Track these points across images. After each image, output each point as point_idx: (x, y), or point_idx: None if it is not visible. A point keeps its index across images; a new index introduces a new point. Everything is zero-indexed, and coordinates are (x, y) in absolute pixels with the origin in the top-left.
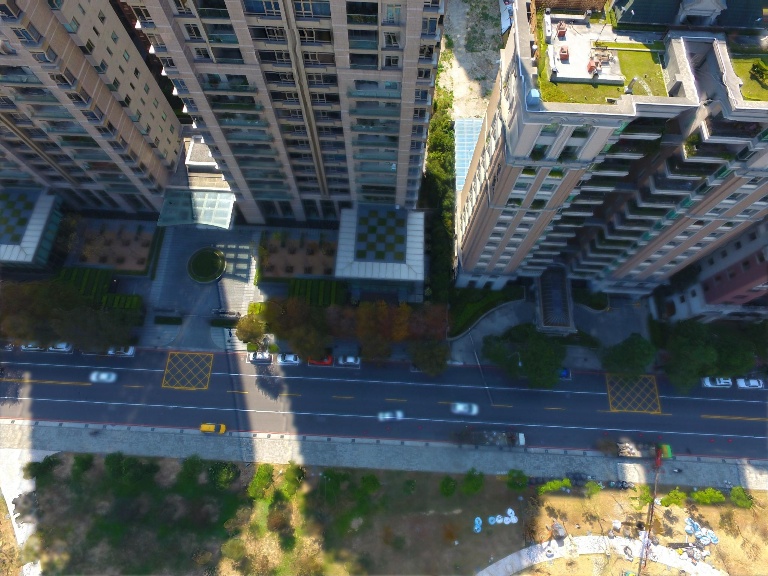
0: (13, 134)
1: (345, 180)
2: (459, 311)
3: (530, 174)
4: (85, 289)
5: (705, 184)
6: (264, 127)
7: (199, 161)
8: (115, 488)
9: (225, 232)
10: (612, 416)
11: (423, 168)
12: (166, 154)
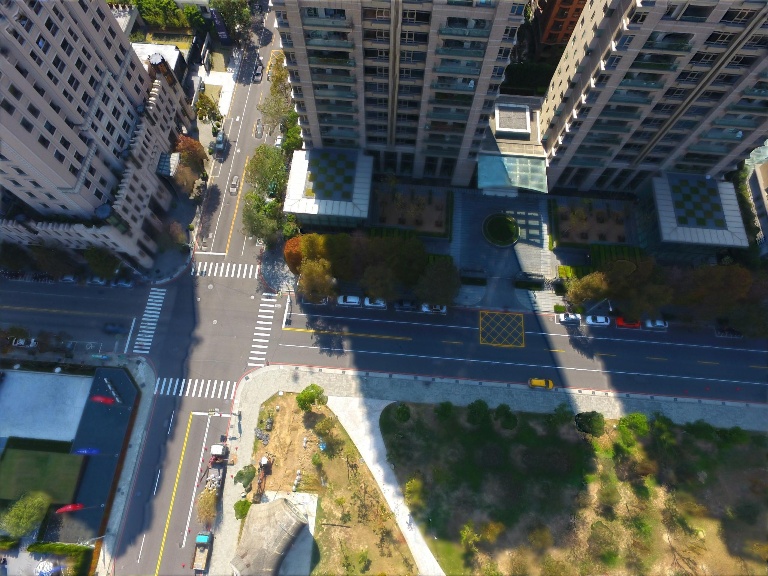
0: (381, 92)
1: (667, 148)
2: None
3: None
4: None
5: None
6: (659, 88)
7: (509, 128)
8: (460, 437)
9: (512, 199)
10: None
11: None
12: None
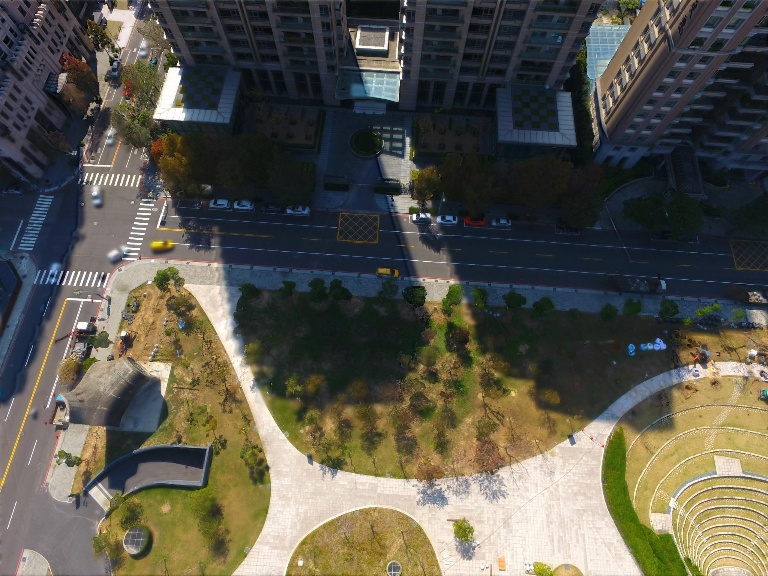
0: (230, 2)
1: (505, 59)
2: None
3: (726, 6)
4: None
5: None
6: None
7: (368, 45)
8: (308, 317)
9: (380, 116)
10: (738, 273)
11: None
12: (343, 35)
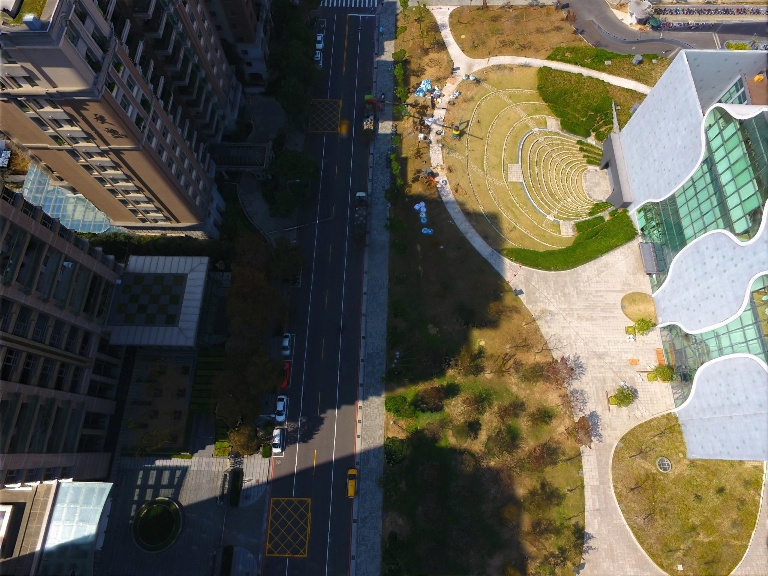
0: None
1: (72, 332)
2: None
3: (113, 88)
4: None
5: None
6: None
7: None
8: None
9: (114, 506)
10: (343, 132)
11: None
12: None
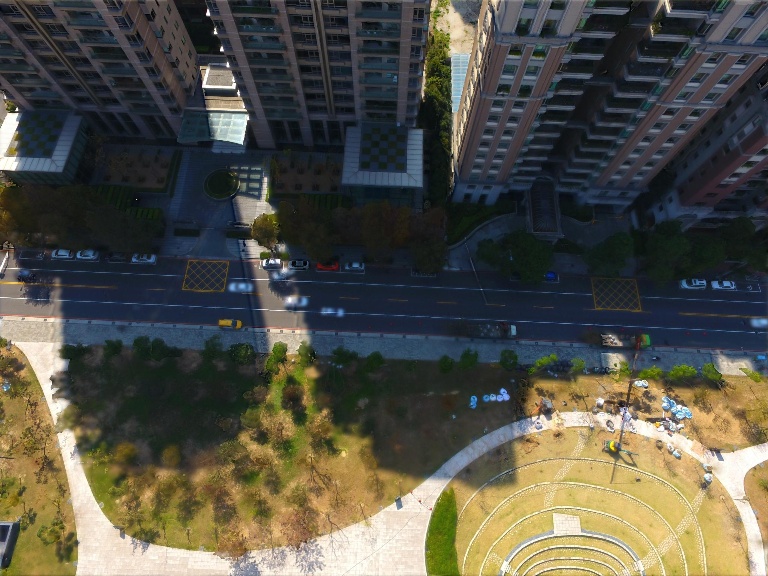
0: (48, 49)
1: (350, 97)
2: (456, 223)
3: (516, 55)
4: (110, 202)
5: (671, 66)
6: (278, 33)
7: (215, 85)
8: (141, 375)
9: (238, 156)
10: (596, 313)
11: (422, 93)
12: (185, 76)
